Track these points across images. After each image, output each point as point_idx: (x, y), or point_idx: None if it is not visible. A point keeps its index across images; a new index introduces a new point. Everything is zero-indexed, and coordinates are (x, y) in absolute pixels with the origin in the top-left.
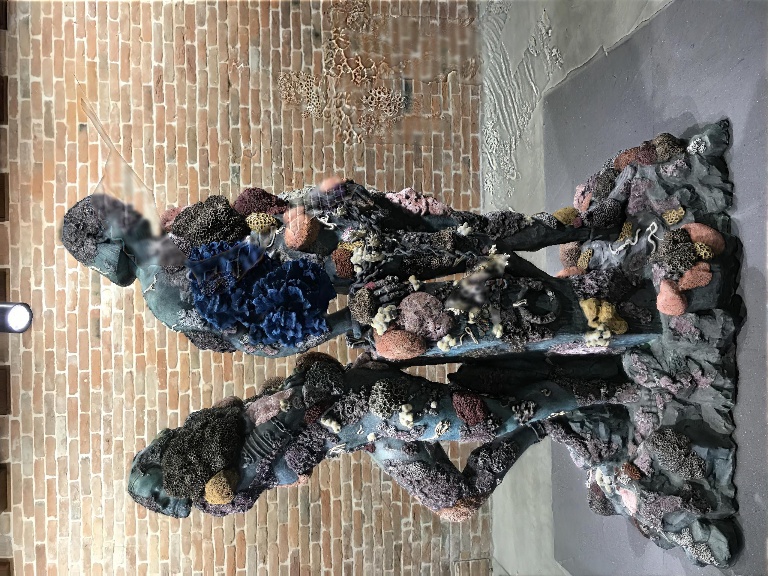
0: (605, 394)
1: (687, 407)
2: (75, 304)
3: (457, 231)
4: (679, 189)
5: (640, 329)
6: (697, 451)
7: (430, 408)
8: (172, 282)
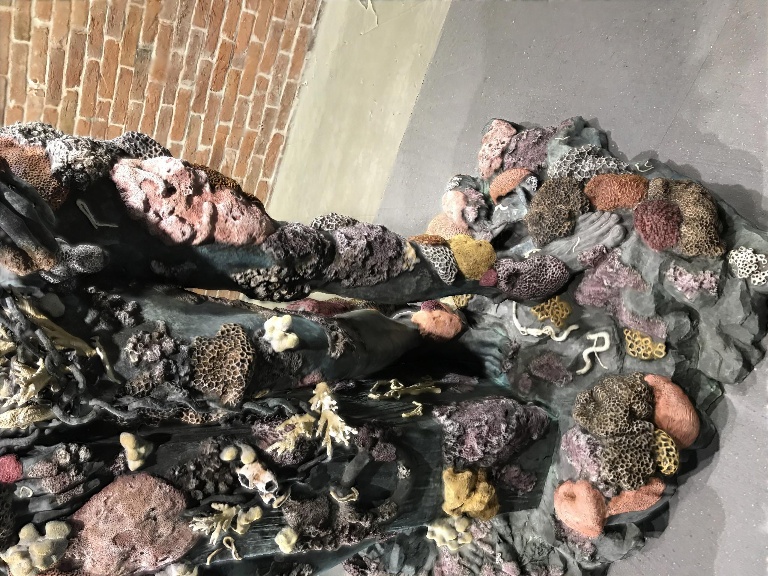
0: None
1: None
2: None
3: (263, 330)
4: (677, 312)
5: (512, 504)
6: None
7: None
8: None
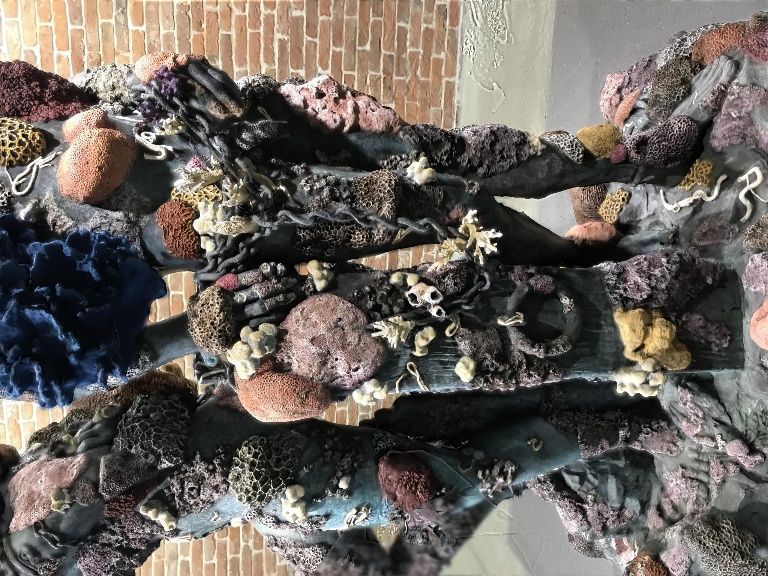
0: (625, 438)
1: (761, 485)
2: None
3: (406, 173)
4: None
5: (708, 361)
6: None
7: (337, 488)
8: None
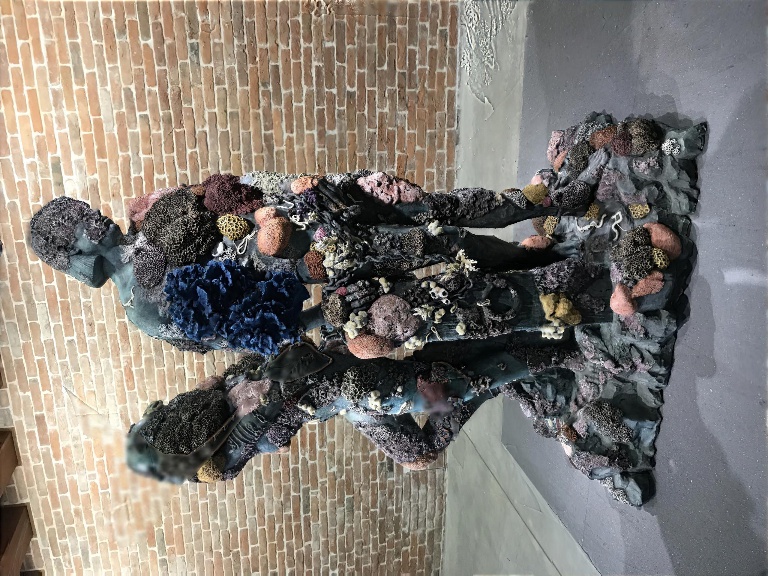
0: (555, 362)
1: (625, 384)
2: (38, 195)
3: (428, 229)
4: (648, 185)
5: (592, 319)
6: (627, 423)
7: (396, 392)
8: (149, 298)
